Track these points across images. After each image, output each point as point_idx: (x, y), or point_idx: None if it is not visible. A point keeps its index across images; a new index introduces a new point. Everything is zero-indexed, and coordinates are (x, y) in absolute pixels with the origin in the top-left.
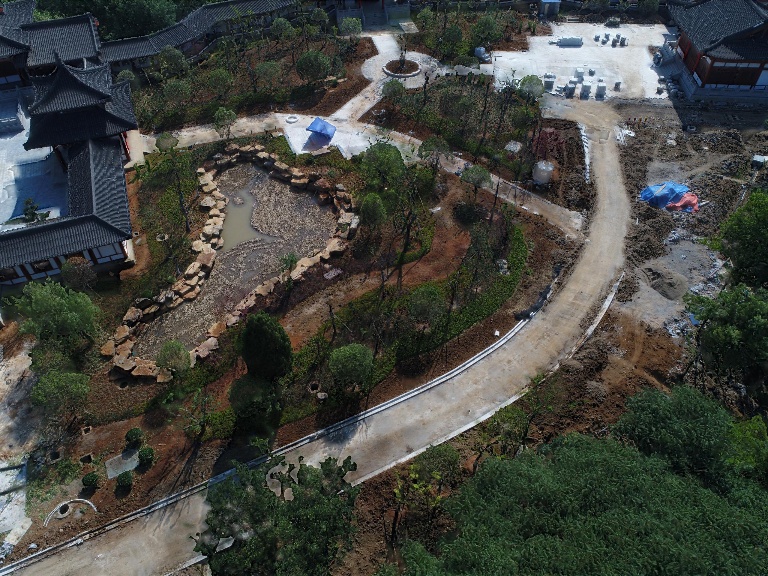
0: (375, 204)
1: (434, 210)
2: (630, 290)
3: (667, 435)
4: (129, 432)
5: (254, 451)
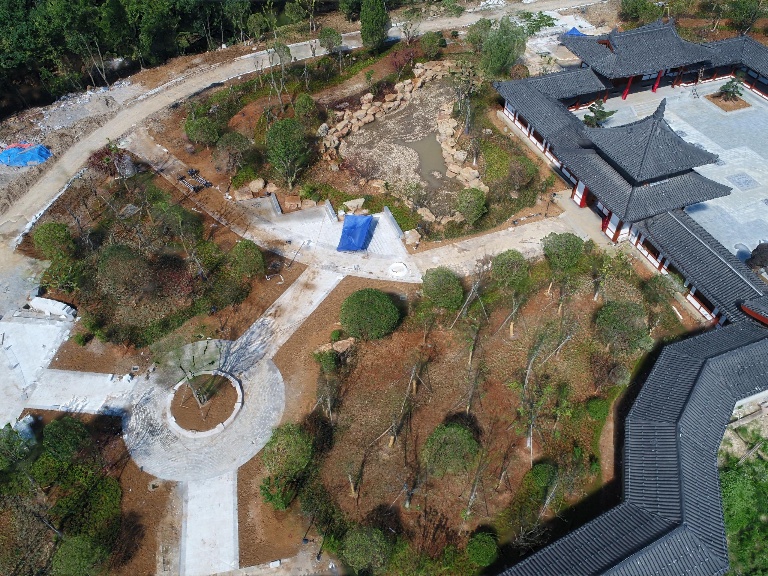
0: None
1: None
2: None
3: None
4: None
5: None
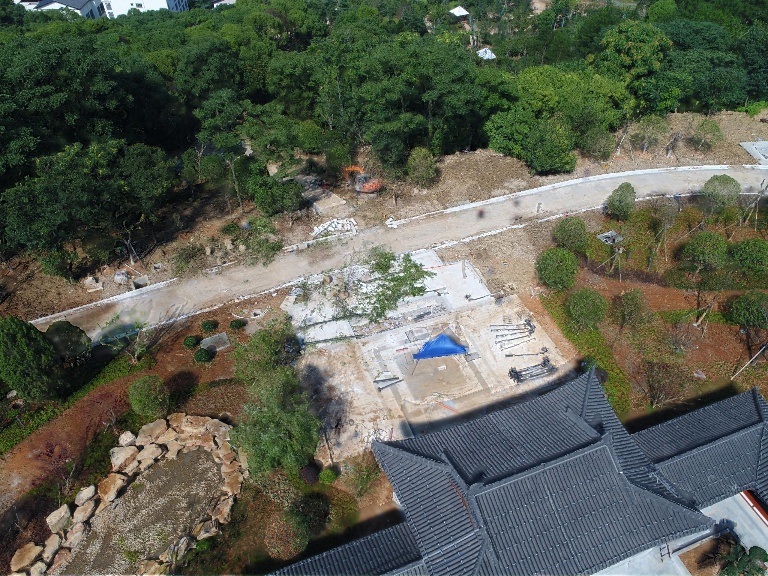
0: None
1: None
2: None
3: None
4: (204, 352)
5: (98, 351)
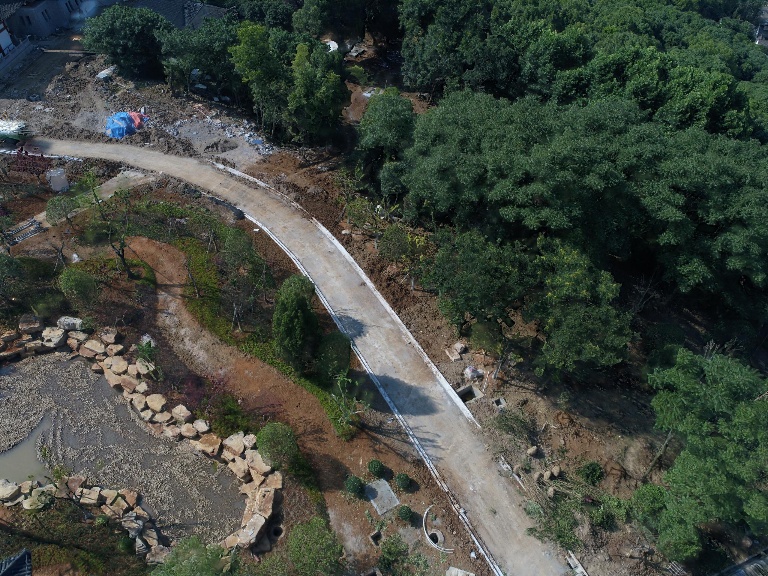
0: (82, 274)
1: (76, 259)
2: (224, 161)
3: (407, 112)
4: (354, 485)
5: (366, 384)
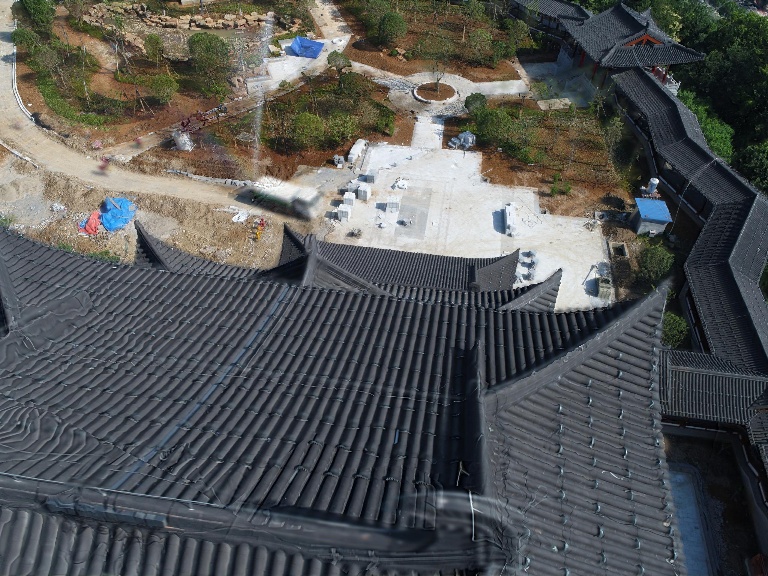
0: None
1: None
2: (20, 167)
3: None
4: None
5: None
